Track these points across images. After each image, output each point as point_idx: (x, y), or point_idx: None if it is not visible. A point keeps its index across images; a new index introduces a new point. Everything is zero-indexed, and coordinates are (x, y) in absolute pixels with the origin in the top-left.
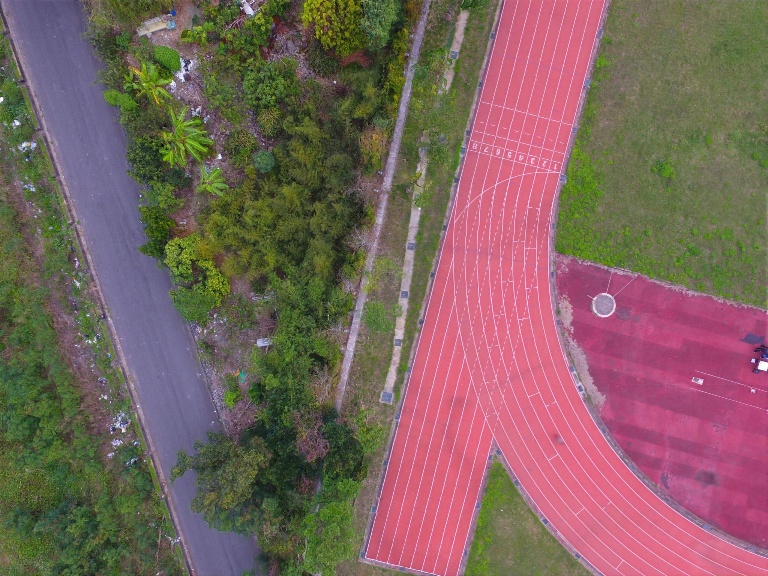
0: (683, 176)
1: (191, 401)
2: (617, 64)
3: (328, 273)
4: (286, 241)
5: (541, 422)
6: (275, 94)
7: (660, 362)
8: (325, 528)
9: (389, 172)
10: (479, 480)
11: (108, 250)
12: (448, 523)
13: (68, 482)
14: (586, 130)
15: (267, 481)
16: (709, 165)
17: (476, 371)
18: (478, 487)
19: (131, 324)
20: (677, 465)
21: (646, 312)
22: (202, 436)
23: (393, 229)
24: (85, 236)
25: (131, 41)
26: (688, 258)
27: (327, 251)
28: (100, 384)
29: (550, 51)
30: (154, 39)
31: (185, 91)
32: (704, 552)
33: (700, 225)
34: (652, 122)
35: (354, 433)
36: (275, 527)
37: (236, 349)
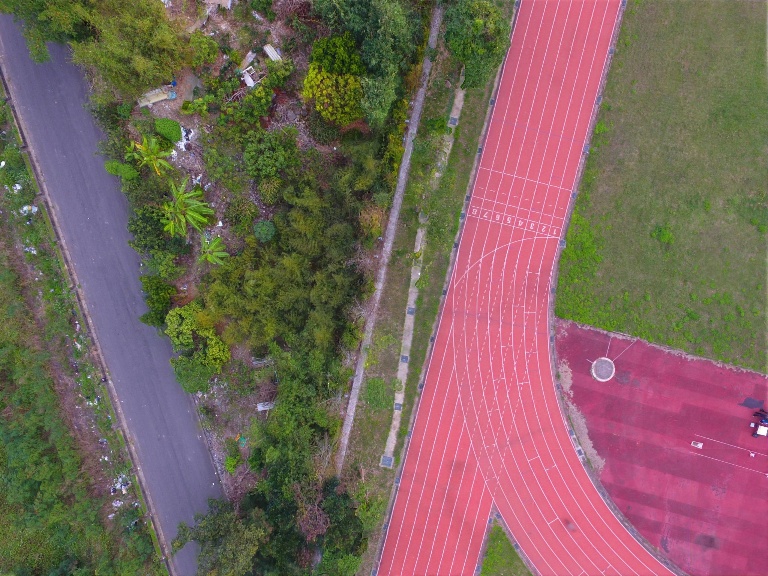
0: (682, 241)
1: (191, 463)
2: (616, 130)
3: (328, 343)
4: (286, 310)
5: (541, 486)
6: (275, 165)
7: (659, 426)
8: None
9: (389, 237)
10: (479, 544)
11: (109, 313)
12: None
13: None
14: (585, 196)
15: (267, 554)
16: (708, 230)
17: (476, 435)
18: (478, 551)
19: (132, 387)
20: (677, 529)
21: (645, 376)
22: (202, 498)
23: (393, 294)
24: (86, 300)
25: (132, 110)
26: (687, 323)
27: (327, 322)
28: (101, 445)
29: (549, 117)
30: (155, 109)
31: (186, 160)
32: None
33: (699, 290)
34: (651, 187)
35: (354, 497)
36: None
37: (236, 413)
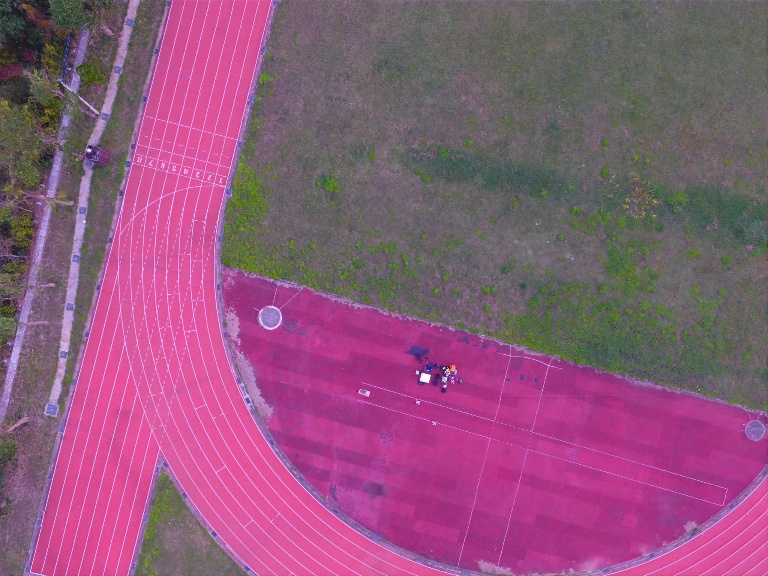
0: (347, 190)
1: None
2: (280, 80)
3: None
4: None
5: (208, 434)
6: None
7: (327, 374)
8: None
9: (53, 185)
10: (146, 493)
11: None
12: (114, 536)
13: None
14: (250, 144)
15: None
16: (373, 180)
17: (142, 383)
18: (145, 500)
19: None
20: (345, 477)
21: (312, 324)
22: None
23: (57, 242)
24: None
25: None
26: (353, 271)
27: None
28: None
29: (213, 67)
30: None
31: None
32: (373, 564)
33: (364, 239)
34: (316, 137)
35: (18, 446)
36: None
37: None
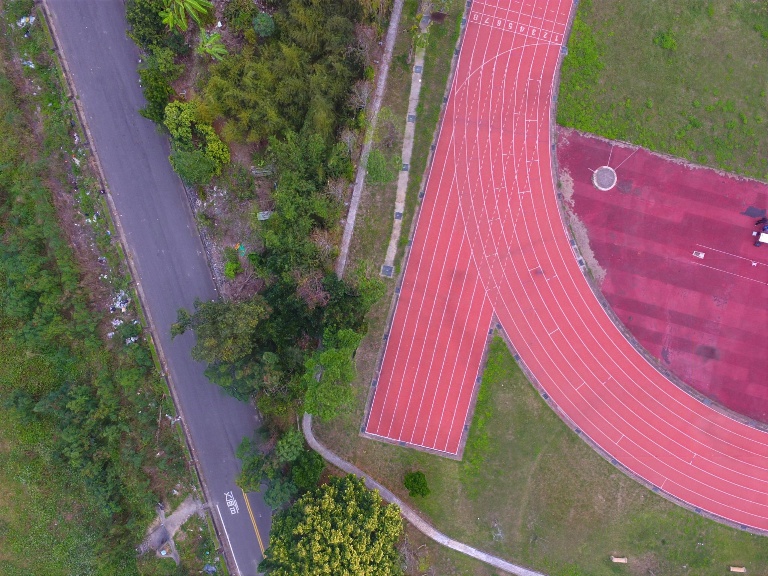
0: (685, 48)
1: (191, 279)
2: None
3: (328, 134)
4: (286, 104)
5: (542, 296)
6: None
7: (661, 236)
8: (325, 371)
9: (389, 43)
10: (479, 354)
11: (107, 125)
12: (448, 397)
13: (68, 367)
14: (587, 1)
15: (267, 337)
16: (711, 37)
17: (477, 244)
18: (478, 361)
19: (131, 200)
20: (678, 340)
21: (647, 185)
22: None
23: (393, 101)
24: (84, 111)
25: None
26: (689, 131)
27: (327, 111)
28: (100, 264)
29: None
30: None
31: None
32: (704, 427)
33: (702, 97)
34: None
35: None
36: (275, 378)
37: (236, 222)
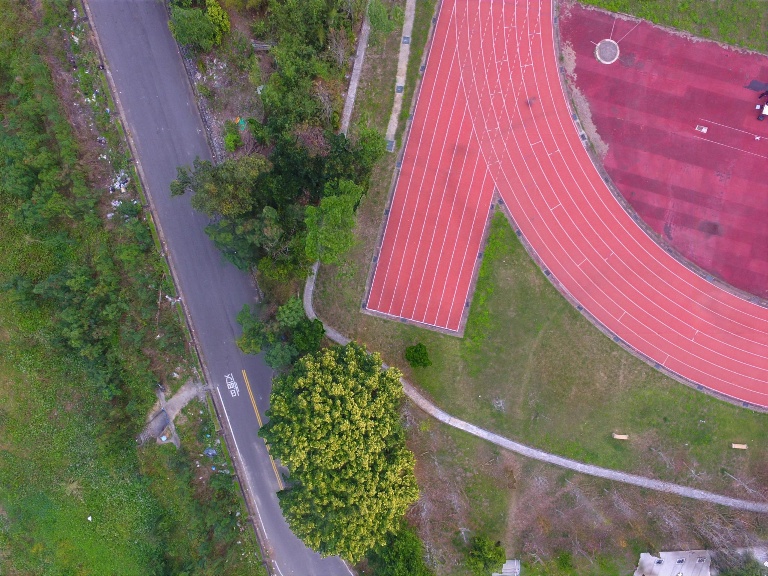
0: None
1: (191, 157)
2: None
3: None
4: None
5: (544, 171)
6: None
7: (664, 110)
8: (326, 215)
9: None
10: (481, 230)
11: (106, 0)
12: (450, 273)
13: (68, 254)
14: None
15: (268, 194)
16: None
17: (478, 118)
18: (480, 237)
19: (130, 77)
20: (680, 215)
21: (650, 59)
22: None
23: None
24: None
25: None
26: (693, 3)
27: None
28: (99, 144)
29: None
30: None
31: None
32: (707, 303)
33: None
34: None
35: None
36: (276, 230)
37: (236, 96)
